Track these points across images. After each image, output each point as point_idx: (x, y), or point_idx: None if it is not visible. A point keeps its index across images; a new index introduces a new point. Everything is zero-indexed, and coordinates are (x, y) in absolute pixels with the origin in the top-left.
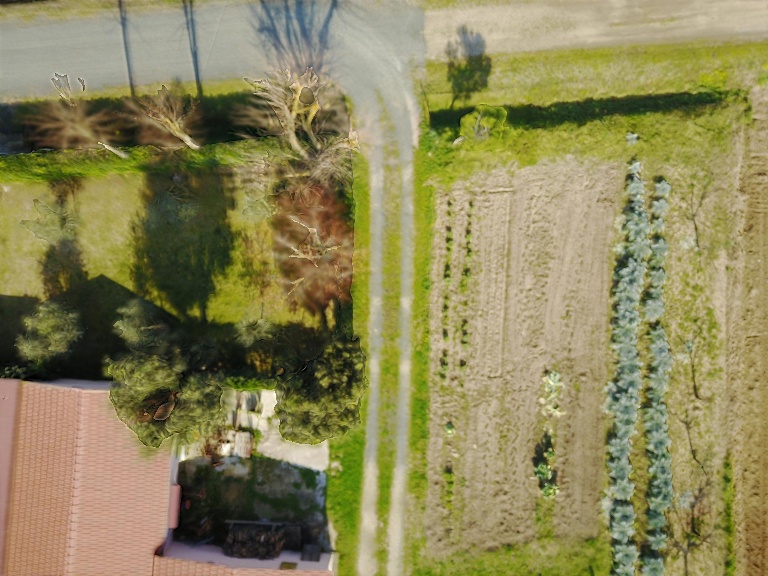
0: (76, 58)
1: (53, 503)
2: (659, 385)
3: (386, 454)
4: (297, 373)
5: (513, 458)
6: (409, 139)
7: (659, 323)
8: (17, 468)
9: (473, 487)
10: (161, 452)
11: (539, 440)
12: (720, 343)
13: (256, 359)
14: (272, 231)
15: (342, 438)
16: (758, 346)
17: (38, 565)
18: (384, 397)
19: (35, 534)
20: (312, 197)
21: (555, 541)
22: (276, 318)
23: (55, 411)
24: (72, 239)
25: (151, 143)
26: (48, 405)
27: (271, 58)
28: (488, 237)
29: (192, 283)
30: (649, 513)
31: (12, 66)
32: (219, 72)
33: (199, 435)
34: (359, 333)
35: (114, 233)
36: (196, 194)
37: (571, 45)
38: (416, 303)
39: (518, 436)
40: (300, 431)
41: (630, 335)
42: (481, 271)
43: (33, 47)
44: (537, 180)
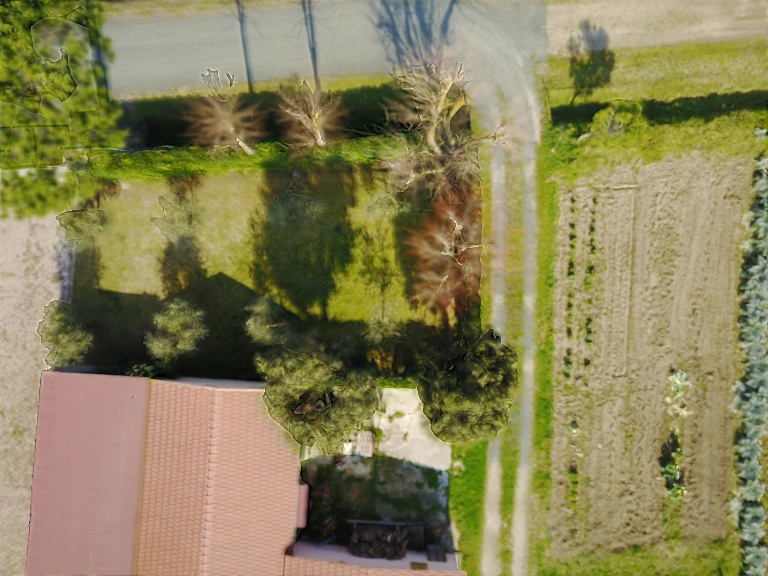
0: (193, 54)
1: (185, 502)
2: None
3: (510, 454)
4: (446, 372)
5: (639, 458)
6: (531, 135)
7: None
8: (146, 467)
9: (598, 487)
10: (290, 451)
11: (665, 440)
12: None
13: (377, 357)
14: (393, 228)
15: None
16: None
17: (170, 564)
18: None
19: (166, 533)
20: (453, 194)
21: (682, 542)
22: (397, 316)
23: (186, 410)
24: (191, 236)
25: (267, 140)
26: (178, 403)
27: (390, 54)
28: (612, 234)
29: (312, 281)
30: None
31: (129, 62)
32: (338, 68)
33: None
34: None
35: (233, 230)
36: (315, 191)
37: (696, 39)
38: (539, 301)
39: (644, 436)
40: (459, 430)
41: (760, 334)
42: (605, 269)
43: (150, 43)
44: (662, 176)
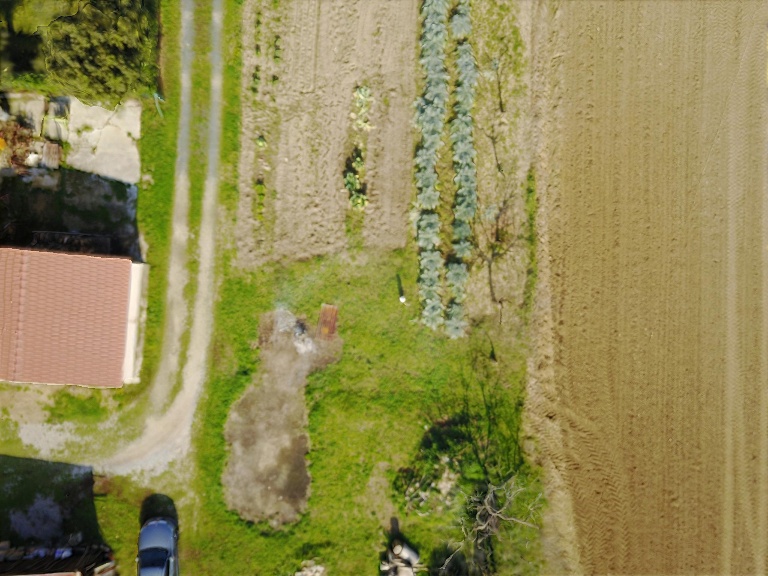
0: None
1: None
2: (465, 98)
3: (197, 167)
4: None
5: (324, 171)
6: None
7: (467, 40)
8: None
9: (284, 200)
10: None
11: (350, 154)
12: (525, 60)
13: None
14: None
15: (154, 152)
16: (562, 64)
17: None
18: (196, 111)
19: None
20: None
21: (364, 251)
22: None
23: None
24: None
25: None
26: None
27: None
28: None
29: None
30: (455, 223)
31: None
32: None
33: (5, 145)
34: (171, 47)
35: None
36: None
37: None
38: (229, 18)
39: (329, 150)
40: (61, 57)
41: (437, 48)
42: None
43: None
44: None
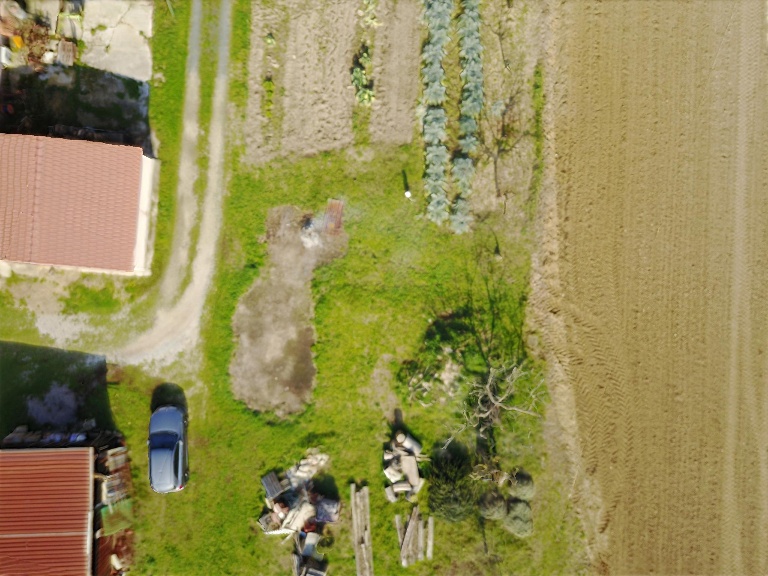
0: None
1: None
2: None
3: (207, 64)
4: None
5: (331, 68)
6: None
7: None
8: None
9: (292, 97)
10: None
11: (357, 51)
12: None
13: None
14: None
15: (165, 50)
16: None
17: None
18: (206, 9)
19: None
20: None
21: (370, 147)
22: None
23: None
24: None
25: None
26: None
27: None
28: None
29: None
30: (460, 119)
31: None
32: None
33: (22, 42)
34: None
35: None
36: None
37: None
38: None
39: (336, 47)
40: None
41: None
42: None
43: None
44: None
